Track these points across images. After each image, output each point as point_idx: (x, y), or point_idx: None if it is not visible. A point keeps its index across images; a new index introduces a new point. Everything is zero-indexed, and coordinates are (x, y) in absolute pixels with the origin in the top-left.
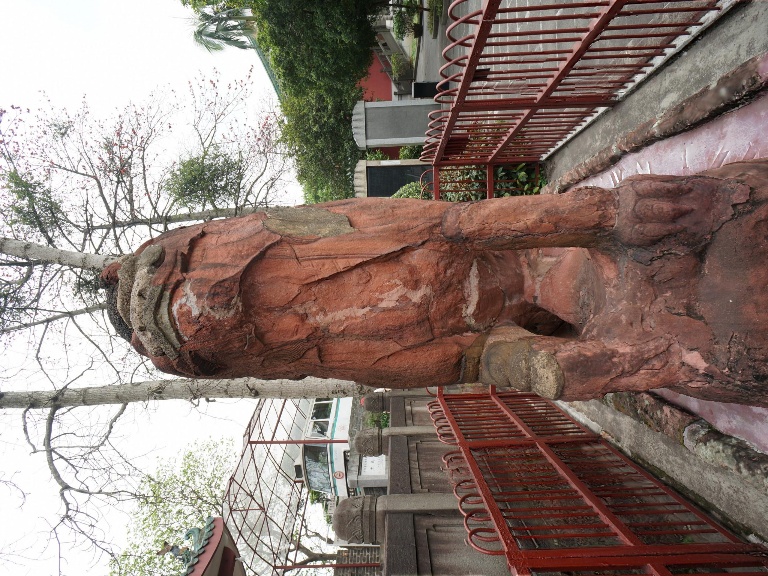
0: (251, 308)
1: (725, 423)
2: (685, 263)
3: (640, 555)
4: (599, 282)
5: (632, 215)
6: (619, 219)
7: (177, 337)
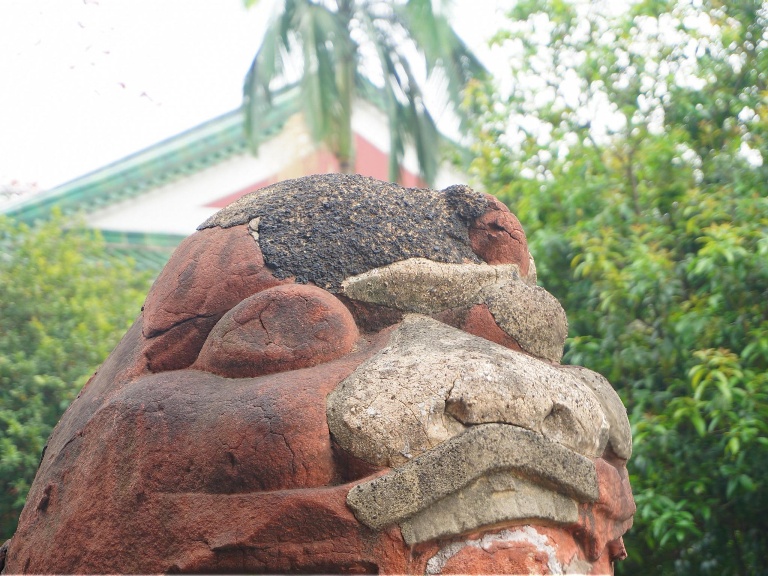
0: None
1: None
2: None
3: None
4: None
5: None
6: None
7: (443, 536)
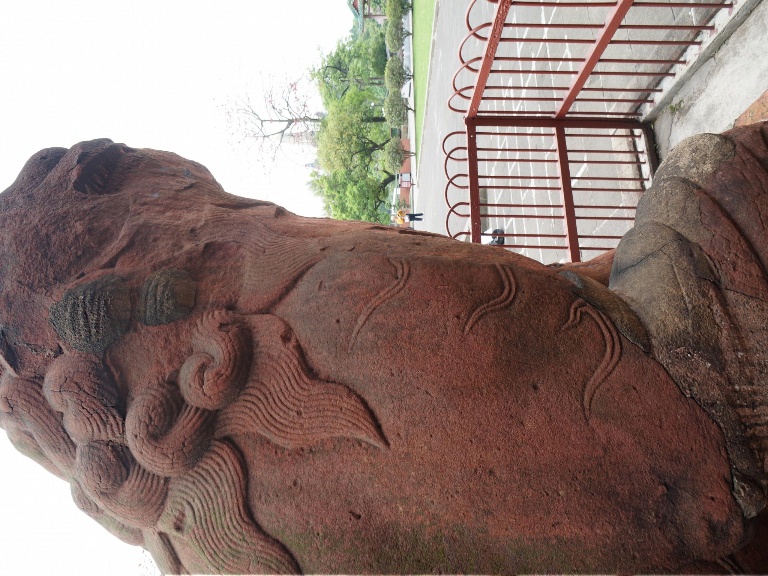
0: None
1: None
2: None
3: None
4: None
5: None
6: None
7: None
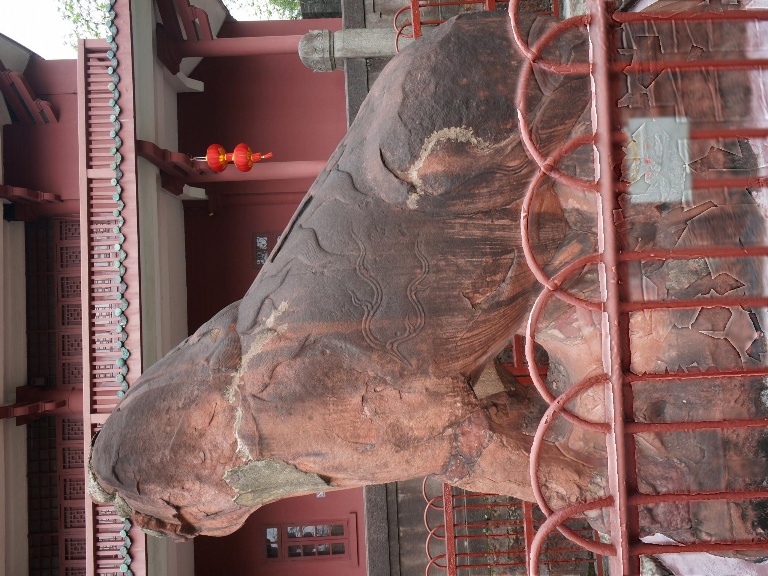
0: None
1: None
2: None
3: (516, 376)
4: None
5: None
6: None
7: None
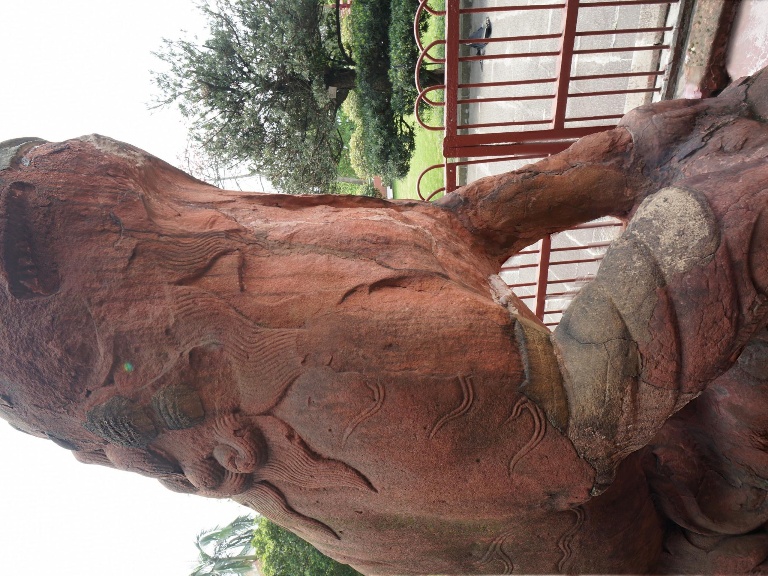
0: (153, 190)
1: None
2: (744, 124)
3: None
4: None
5: (640, 112)
6: (631, 127)
7: (14, 160)
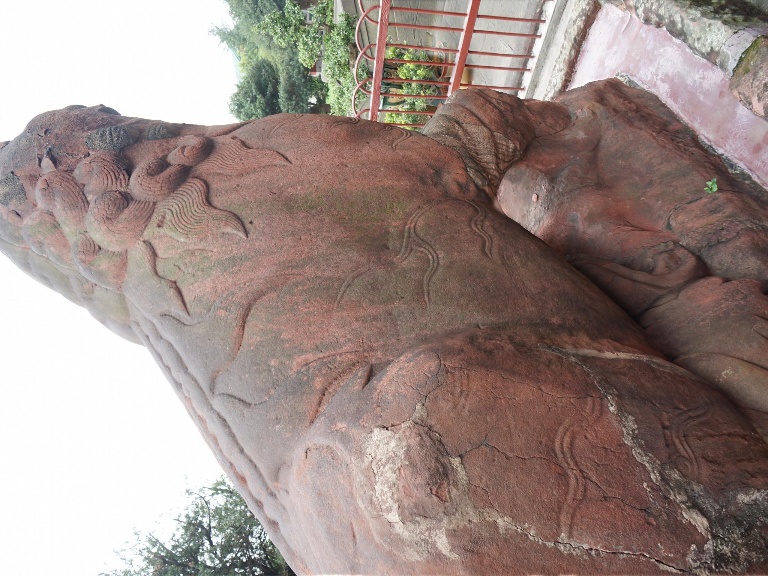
0: None
1: (708, 77)
2: None
3: None
4: (511, 214)
5: None
6: None
7: None
